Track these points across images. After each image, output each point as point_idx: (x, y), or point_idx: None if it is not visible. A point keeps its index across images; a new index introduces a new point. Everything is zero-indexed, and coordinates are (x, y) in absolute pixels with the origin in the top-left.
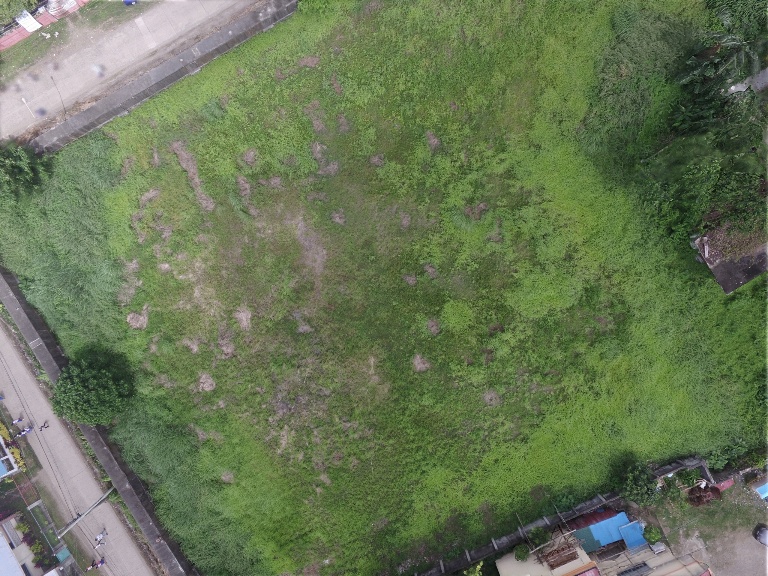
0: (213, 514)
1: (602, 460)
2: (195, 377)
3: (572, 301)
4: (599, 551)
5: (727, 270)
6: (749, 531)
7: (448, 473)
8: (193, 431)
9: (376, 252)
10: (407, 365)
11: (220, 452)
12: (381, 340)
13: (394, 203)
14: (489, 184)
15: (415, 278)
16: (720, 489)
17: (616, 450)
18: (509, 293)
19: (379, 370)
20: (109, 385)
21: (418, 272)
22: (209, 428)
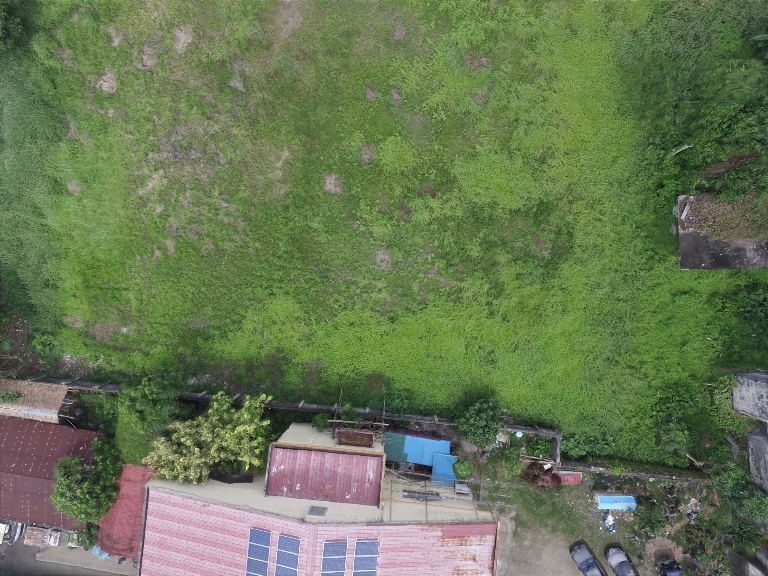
0: (36, 212)
1: (459, 382)
2: (100, 70)
3: (520, 204)
4: None
5: (696, 244)
6: (568, 542)
7: (296, 309)
8: (66, 122)
9: (351, 48)
10: (317, 177)
11: (81, 157)
12: (306, 138)
13: (398, 9)
14: (504, 42)
15: (376, 95)
16: (562, 481)
17: (479, 380)
18: (461, 161)
19: (287, 167)
20: (1, 8)
21: (382, 90)
22: (84, 128)
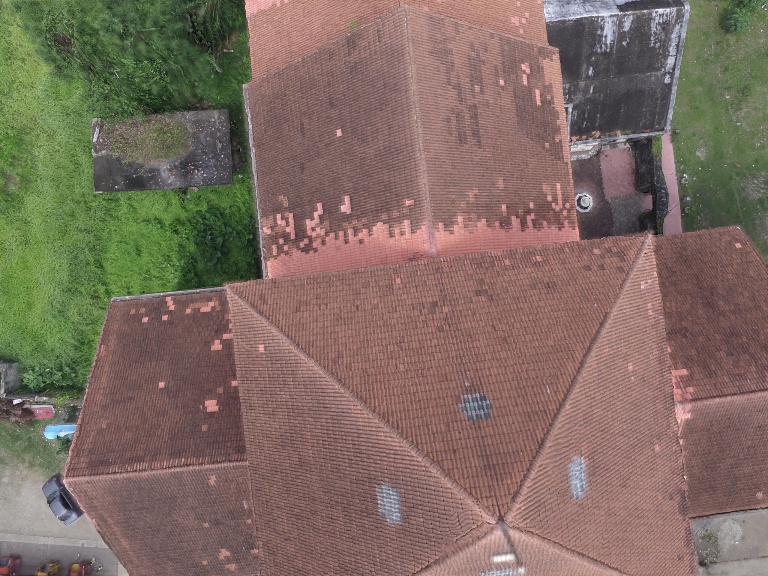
0: None
1: None
2: None
3: None
4: None
5: (109, 166)
6: (46, 476)
7: None
8: None
9: None
10: None
11: None
12: None
13: None
14: None
15: None
16: (36, 416)
17: None
18: None
19: None
20: None
21: None
22: None
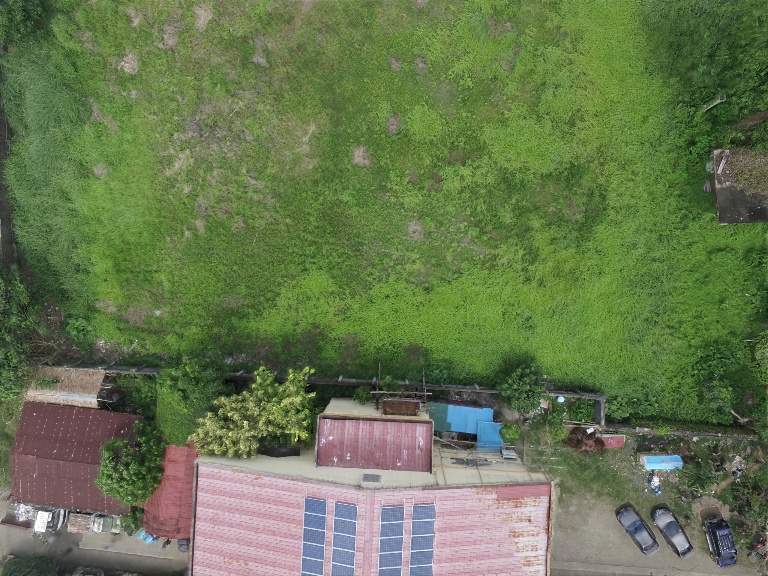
0: (64, 197)
1: (498, 350)
2: (120, 51)
3: (551, 168)
4: (446, 441)
5: (733, 198)
6: (614, 505)
7: (330, 284)
8: (89, 105)
9: (374, 18)
10: (346, 150)
11: (105, 140)
12: (332, 111)
13: None
14: (527, 6)
15: (401, 65)
16: (606, 445)
17: (518, 347)
18: (490, 128)
19: (314, 142)
20: None
21: (407, 60)
22: (107, 110)
